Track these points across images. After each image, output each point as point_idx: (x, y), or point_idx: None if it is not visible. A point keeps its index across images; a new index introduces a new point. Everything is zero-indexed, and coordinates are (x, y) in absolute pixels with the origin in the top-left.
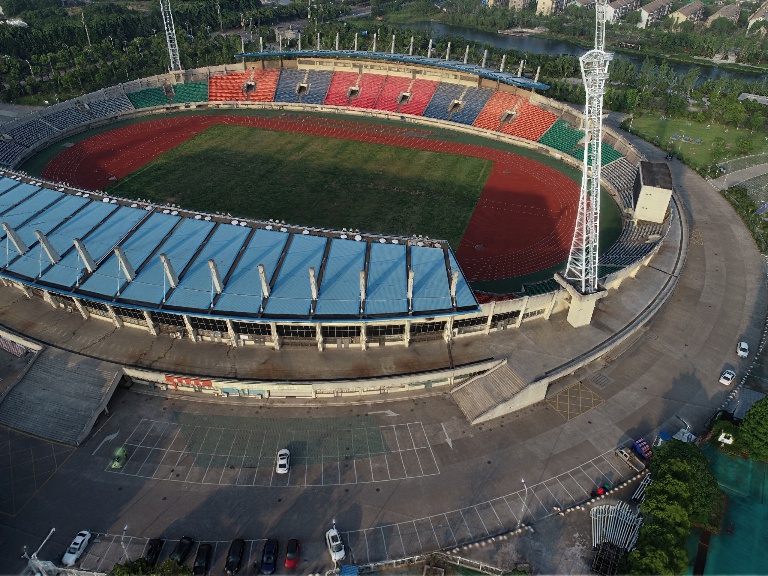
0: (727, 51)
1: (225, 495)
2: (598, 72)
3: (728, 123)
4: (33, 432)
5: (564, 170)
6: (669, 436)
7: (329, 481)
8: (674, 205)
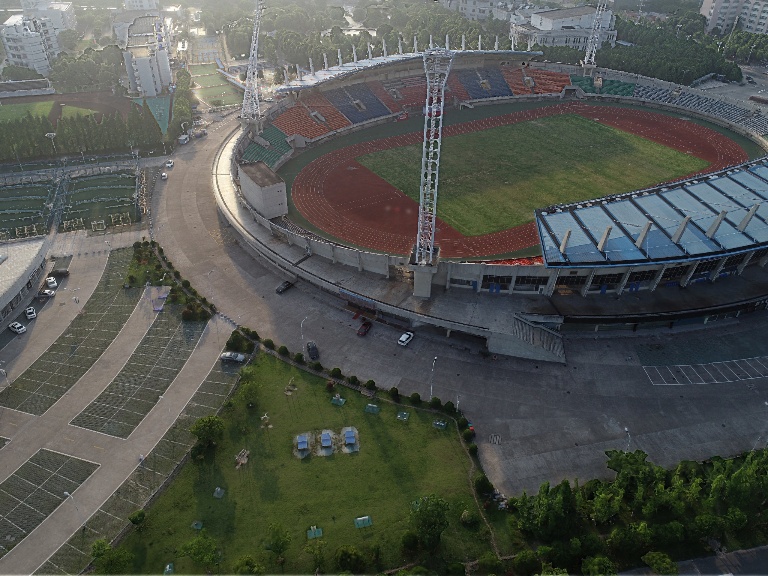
0: None
1: None
2: (259, 2)
3: None
4: None
5: None
6: (189, 130)
7: None
8: (246, 227)
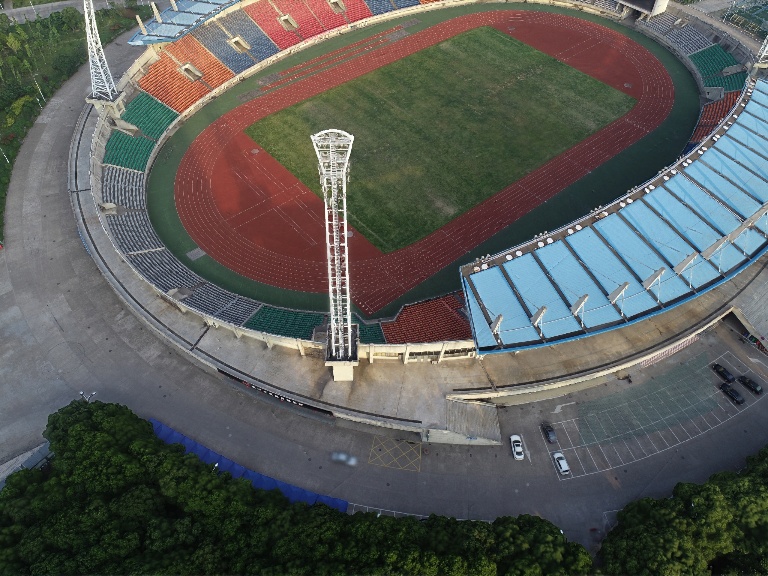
0: None
1: None
2: None
3: None
4: None
5: (527, 8)
6: None
7: None
8: None
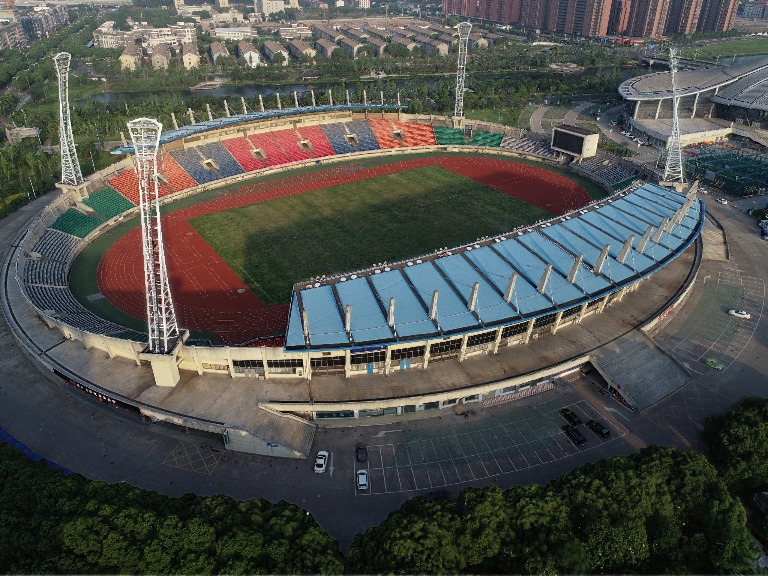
0: (378, 69)
1: (761, 338)
2: None
3: (475, 107)
4: (667, 394)
5: (476, 156)
6: None
7: (760, 308)
8: None
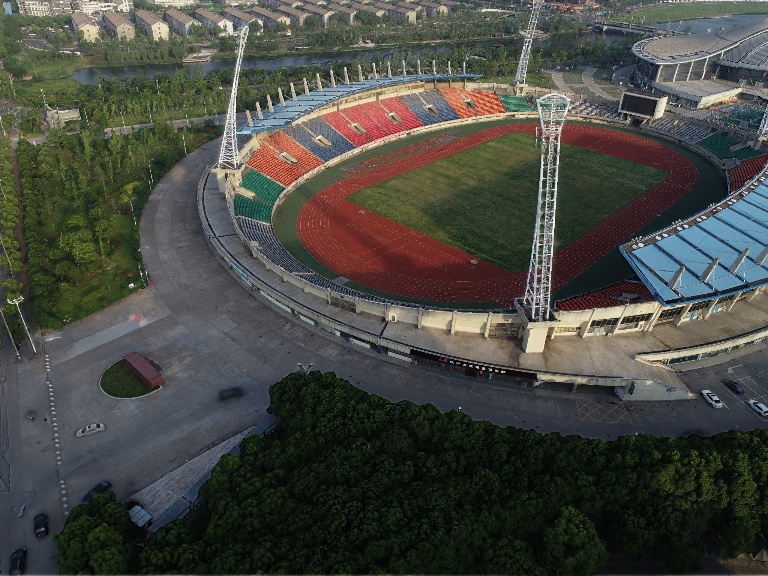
0: (366, 37)
1: None
2: None
3: (498, 75)
4: None
5: None
6: None
7: None
8: None
